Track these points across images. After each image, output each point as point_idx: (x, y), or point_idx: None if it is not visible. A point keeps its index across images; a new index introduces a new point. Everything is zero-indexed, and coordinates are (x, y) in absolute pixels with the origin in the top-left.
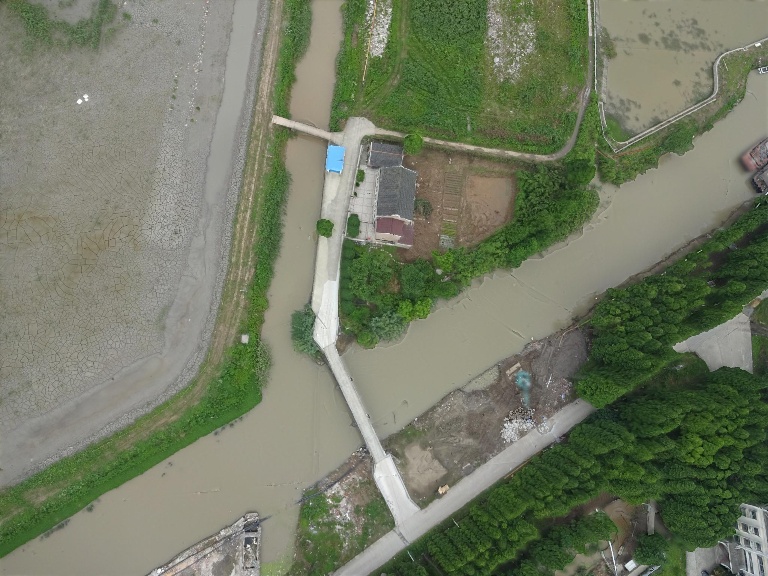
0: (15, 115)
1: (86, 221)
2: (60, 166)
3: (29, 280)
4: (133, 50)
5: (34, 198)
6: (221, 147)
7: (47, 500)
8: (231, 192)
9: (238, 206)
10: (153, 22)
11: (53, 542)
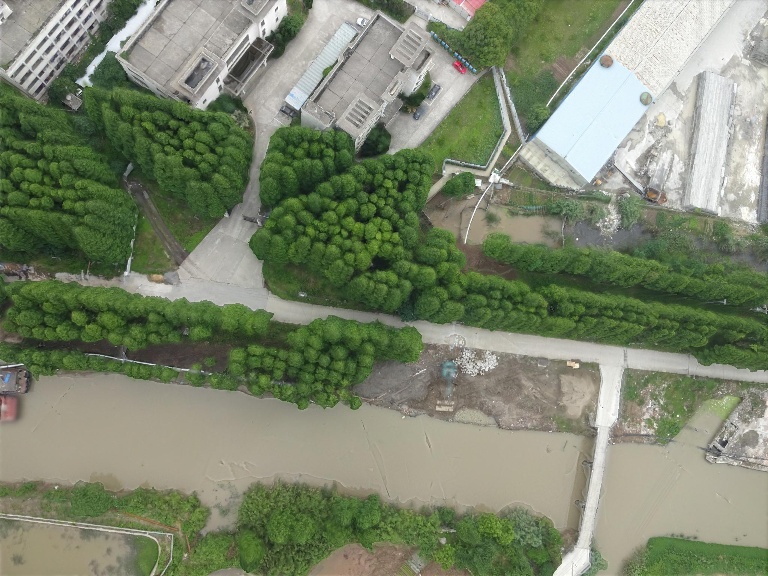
0: None
1: None
2: None
3: None
4: None
5: None
6: None
7: None
8: None
9: None
10: None
11: None
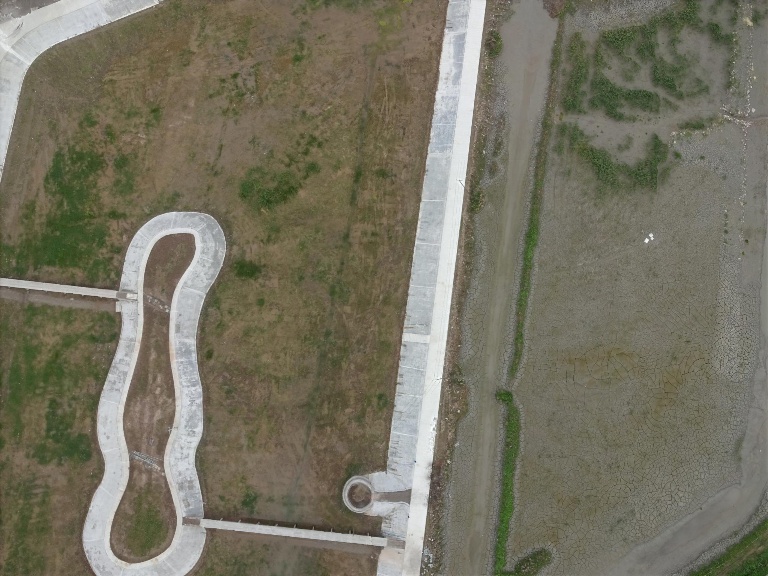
0: (595, 257)
1: (664, 356)
2: (637, 304)
3: (623, 414)
4: (686, 187)
5: (619, 335)
6: None
7: None
8: None
9: None
10: (701, 159)
11: None
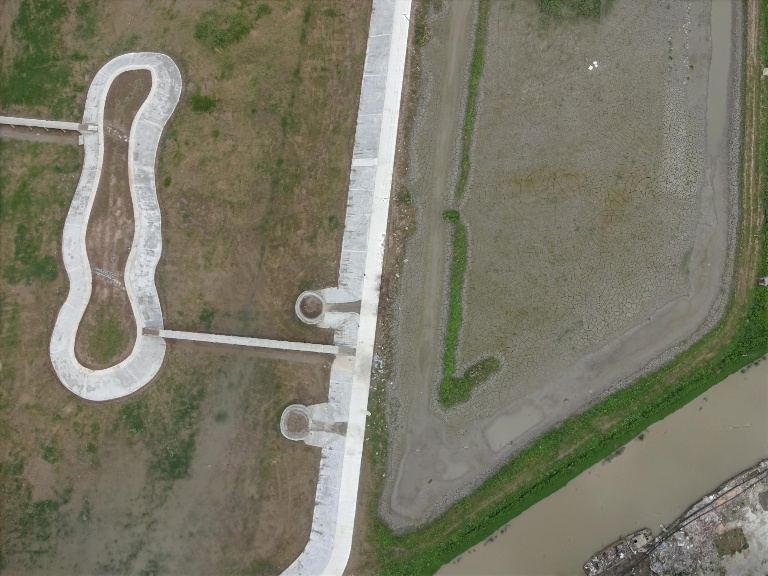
0: (540, 84)
1: (610, 176)
2: (582, 127)
3: (569, 230)
4: (629, 17)
5: (564, 157)
6: (716, 102)
7: (612, 427)
8: (732, 143)
9: (742, 156)
10: None
11: (612, 467)
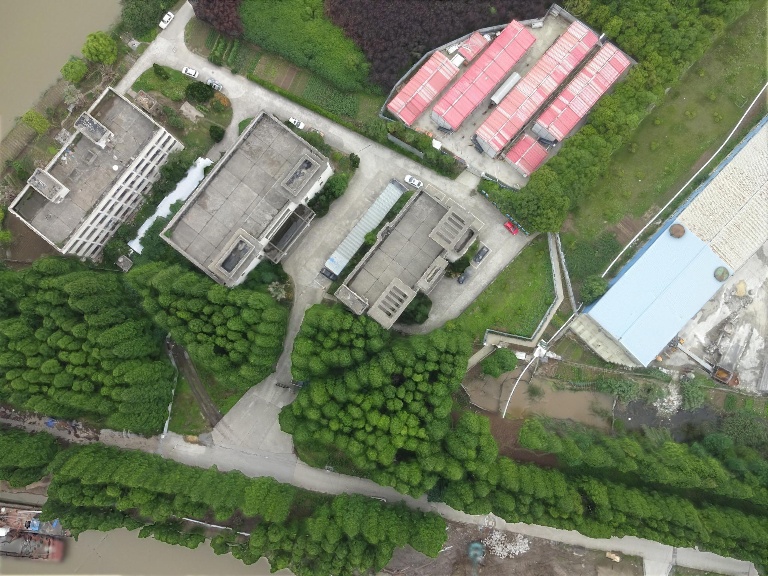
0: None
1: None
2: None
3: None
4: None
5: None
6: None
7: None
8: None
9: None
10: None
11: None
